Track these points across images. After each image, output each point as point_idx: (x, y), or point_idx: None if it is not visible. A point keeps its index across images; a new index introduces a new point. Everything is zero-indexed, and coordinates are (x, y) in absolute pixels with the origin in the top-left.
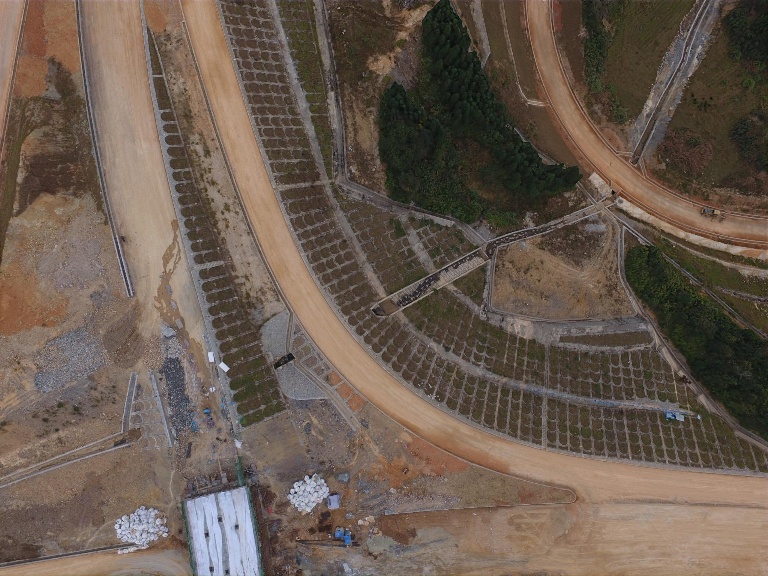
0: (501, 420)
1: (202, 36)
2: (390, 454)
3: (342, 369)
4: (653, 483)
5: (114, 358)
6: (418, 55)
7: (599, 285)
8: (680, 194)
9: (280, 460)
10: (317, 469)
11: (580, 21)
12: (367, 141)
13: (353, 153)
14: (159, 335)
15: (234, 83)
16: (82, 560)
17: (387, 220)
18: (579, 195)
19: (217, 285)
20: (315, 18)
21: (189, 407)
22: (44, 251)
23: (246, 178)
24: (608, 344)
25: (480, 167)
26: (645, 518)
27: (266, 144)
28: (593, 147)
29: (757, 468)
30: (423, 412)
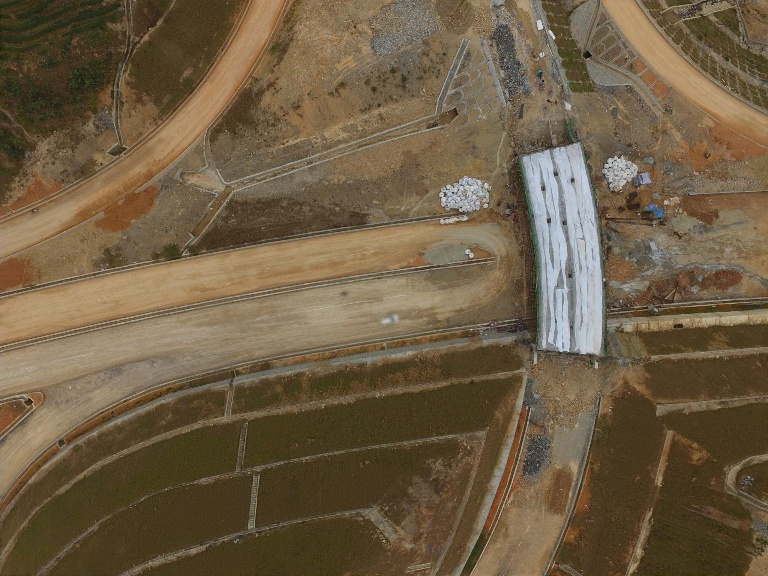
0: None
1: None
2: (693, 139)
3: (646, 57)
4: None
5: (447, 24)
6: None
7: None
8: None
9: (598, 132)
10: (623, 152)
11: None
12: None
13: None
14: (488, 5)
15: None
16: (404, 230)
17: None
18: None
19: None
20: None
21: (520, 71)
22: None
23: None
24: None
25: None
26: None
27: None
28: None
29: None
30: (722, 101)
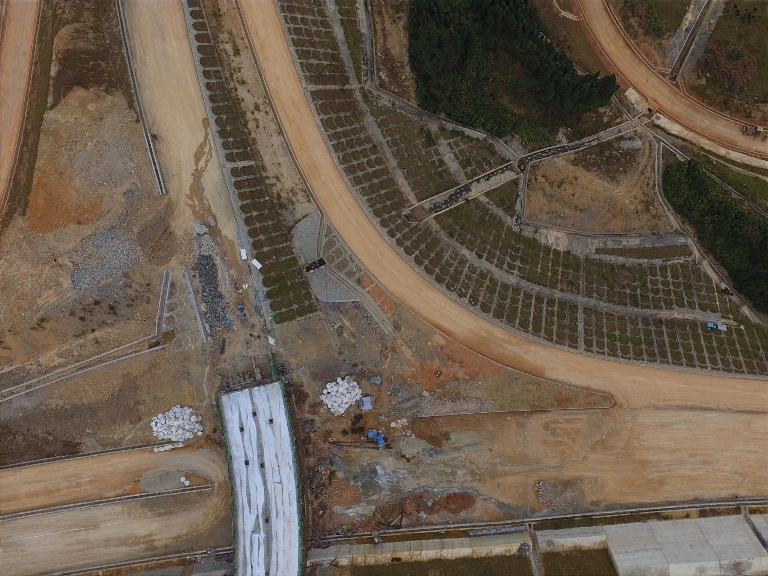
0: (536, 325)
1: None
2: (423, 357)
3: (374, 271)
4: (694, 389)
5: (148, 255)
6: None
7: (635, 201)
8: (721, 111)
9: (313, 359)
10: (349, 372)
11: None
12: (397, 48)
13: (383, 59)
14: (192, 233)
15: None
16: (119, 458)
17: (417, 129)
18: (614, 110)
19: (248, 184)
20: None
21: (222, 304)
22: (78, 148)
23: (276, 78)
24: (646, 256)
25: (512, 79)
26: (685, 425)
27: (296, 43)
28: (629, 63)
29: None
30: (456, 315)
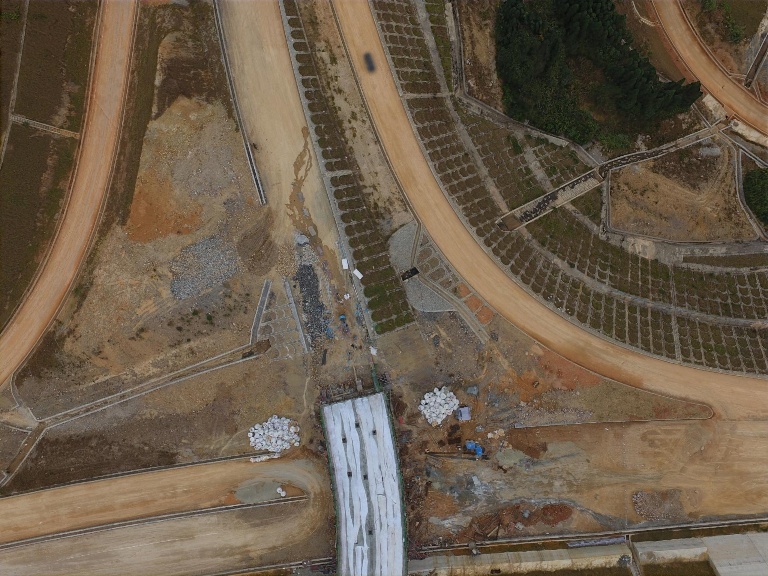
0: (632, 335)
1: None
2: (520, 367)
3: (471, 281)
4: None
5: (248, 265)
6: None
7: (717, 208)
8: None
9: (412, 370)
10: (446, 382)
11: None
12: (484, 55)
13: (471, 66)
14: (292, 242)
15: None
16: (215, 468)
17: (505, 137)
18: (693, 117)
19: (347, 193)
20: None
21: (324, 314)
22: (178, 158)
23: (372, 86)
24: (733, 265)
25: (593, 86)
26: None
27: (392, 51)
28: (705, 69)
29: None
30: (553, 325)
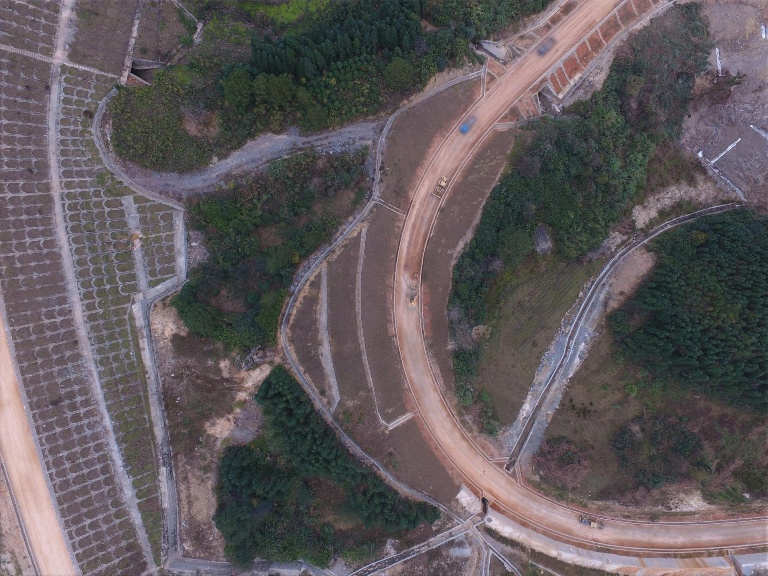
0: None
1: (13, 448)
2: None
3: None
4: None
5: None
6: (260, 412)
7: None
8: (557, 501)
9: None
10: None
11: (447, 336)
12: (204, 510)
13: (187, 528)
14: None
15: (47, 497)
16: None
17: None
18: (443, 519)
19: None
20: (148, 387)
21: None
22: None
23: None
24: None
25: (334, 506)
26: None
27: (81, 557)
28: (465, 455)
29: None
30: None
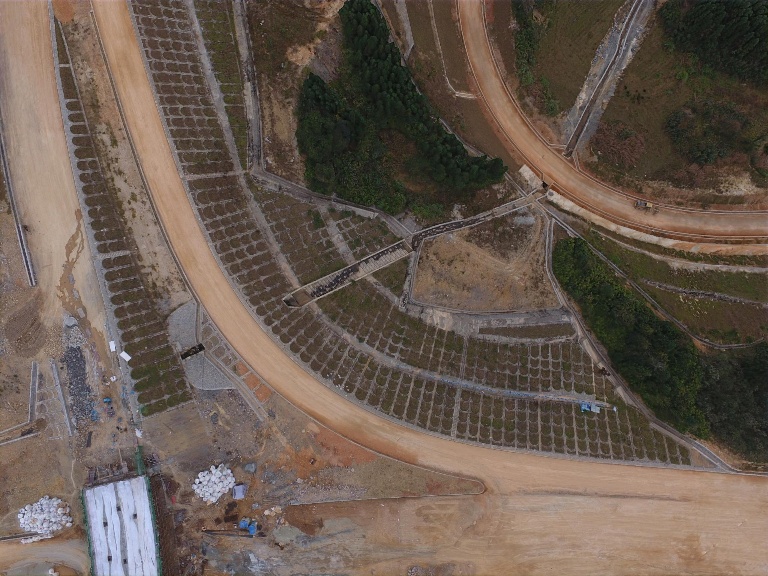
0: (411, 411)
1: (110, 26)
2: (297, 444)
3: (249, 359)
4: (563, 474)
5: (15, 347)
6: (339, 46)
7: (525, 277)
8: (613, 187)
9: (184, 450)
10: (224, 459)
11: (510, 13)
12: (285, 132)
13: (270, 144)
14: (61, 324)
15: (142, 73)
16: None
17: (305, 211)
18: (508, 187)
19: (121, 275)
20: (233, 9)
21: (90, 396)
22: None
23: (154, 168)
24: (528, 336)
25: (405, 159)
26: (555, 509)
27: (174, 134)
28: (525, 140)
29: (668, 460)
30: (331, 402)
